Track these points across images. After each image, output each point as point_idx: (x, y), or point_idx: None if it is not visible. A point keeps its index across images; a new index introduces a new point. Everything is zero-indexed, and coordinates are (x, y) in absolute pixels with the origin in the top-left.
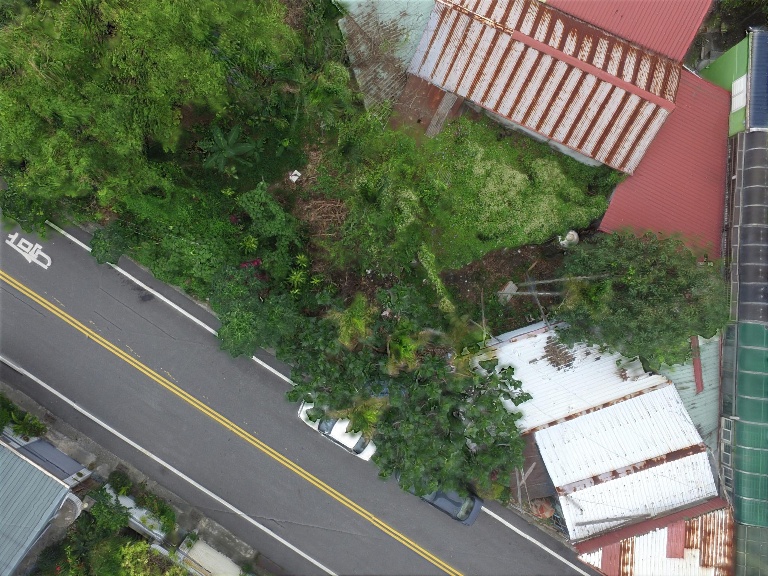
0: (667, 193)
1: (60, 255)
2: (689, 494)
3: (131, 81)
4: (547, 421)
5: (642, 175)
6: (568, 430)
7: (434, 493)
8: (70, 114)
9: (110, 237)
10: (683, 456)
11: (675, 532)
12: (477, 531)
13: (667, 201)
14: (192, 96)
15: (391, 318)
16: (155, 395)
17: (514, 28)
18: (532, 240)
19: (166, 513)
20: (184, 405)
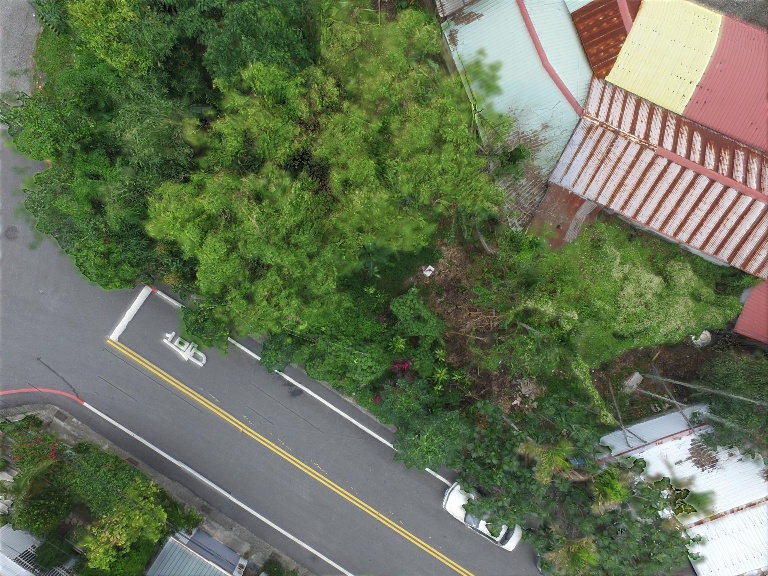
0: None
1: (214, 353)
2: None
3: (304, 203)
4: (693, 520)
5: None
6: (710, 527)
7: None
8: (288, 263)
9: (280, 348)
10: None
11: None
12: None
13: None
14: (350, 209)
15: (522, 408)
16: (306, 487)
17: (657, 144)
18: (667, 340)
19: None
20: (333, 496)
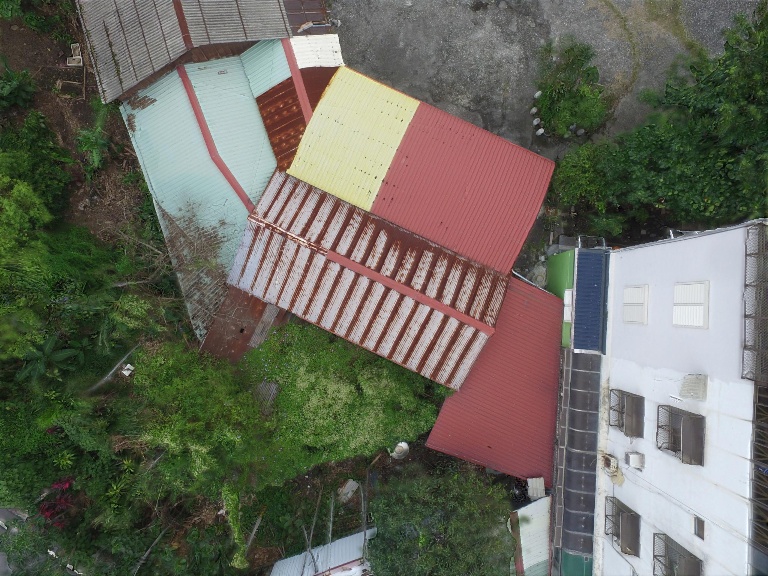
0: (497, 406)
1: None
2: None
3: None
4: None
5: (471, 388)
6: None
7: None
8: None
9: None
10: None
11: None
12: None
13: (497, 414)
14: None
15: None
16: None
17: (330, 247)
18: (360, 453)
19: None
20: None
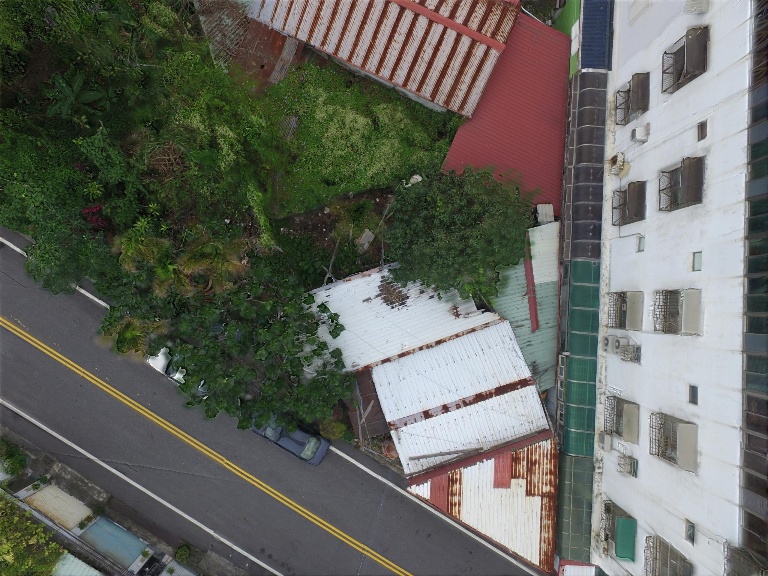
0: (508, 136)
1: None
2: (520, 428)
3: None
4: (380, 358)
5: (482, 118)
6: (404, 368)
7: (279, 433)
8: None
9: None
10: (512, 390)
11: (502, 463)
12: (329, 472)
13: (508, 144)
14: (26, 40)
15: (248, 266)
16: (5, 343)
17: None
18: (376, 184)
19: (14, 457)
20: (34, 352)
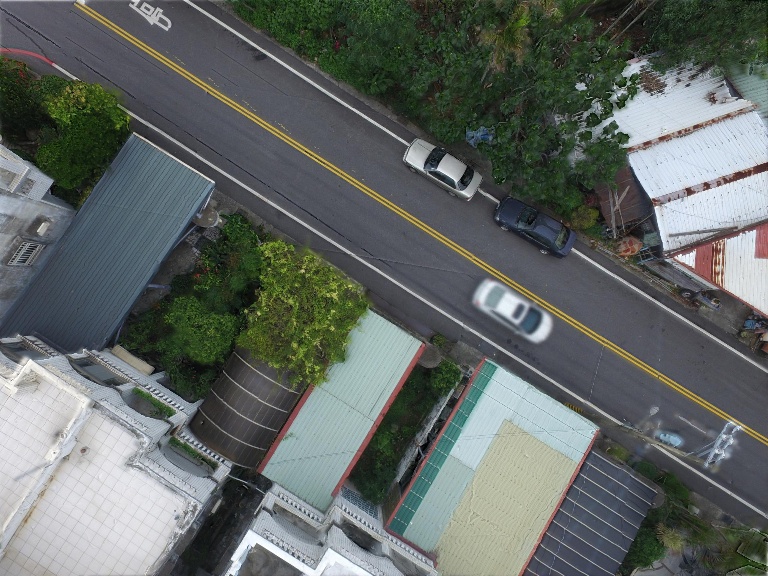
0: None
1: (179, 18)
2: None
3: None
4: (642, 141)
5: None
6: (660, 154)
7: (532, 224)
8: None
9: None
10: None
11: (763, 234)
12: (569, 270)
13: None
14: None
15: None
16: (270, 145)
17: None
18: None
19: None
20: (297, 154)
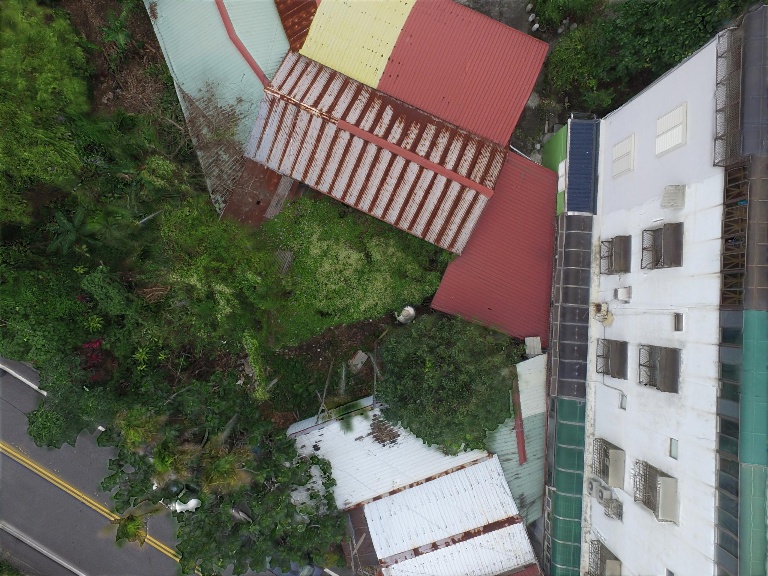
0: (496, 271)
1: None
2: (508, 562)
3: None
4: (372, 496)
5: (472, 254)
6: (395, 502)
7: None
8: None
9: None
10: (499, 528)
11: None
12: None
13: (496, 278)
14: (28, 185)
15: (244, 387)
16: (7, 470)
17: (340, 117)
18: (369, 316)
19: None
20: (35, 479)
